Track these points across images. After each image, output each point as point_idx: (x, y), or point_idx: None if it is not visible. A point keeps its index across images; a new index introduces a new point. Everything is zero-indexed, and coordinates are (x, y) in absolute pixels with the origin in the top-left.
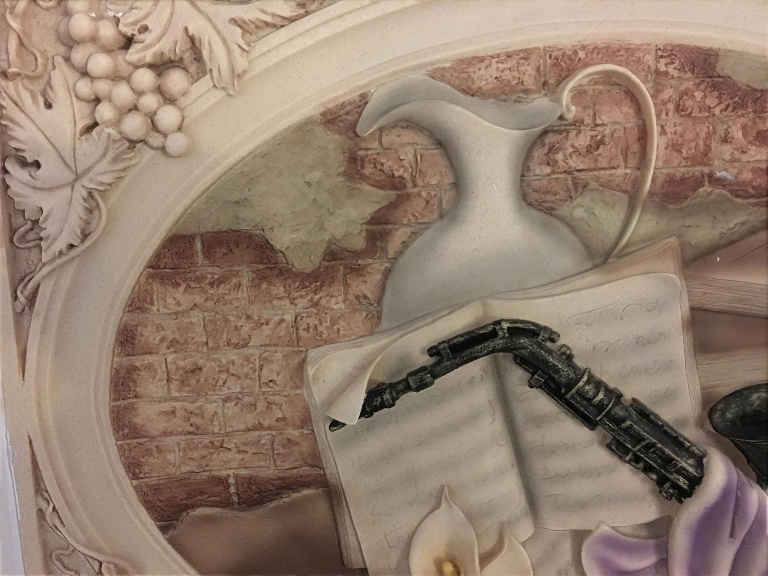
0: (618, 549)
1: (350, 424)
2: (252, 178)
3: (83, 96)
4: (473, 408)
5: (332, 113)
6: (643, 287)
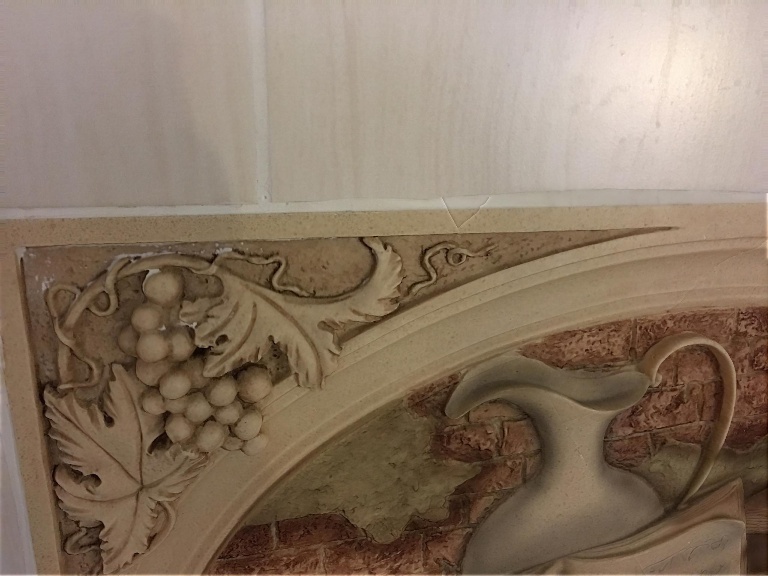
0: None
1: None
2: (334, 465)
3: (153, 414)
4: None
5: (420, 396)
6: (711, 530)
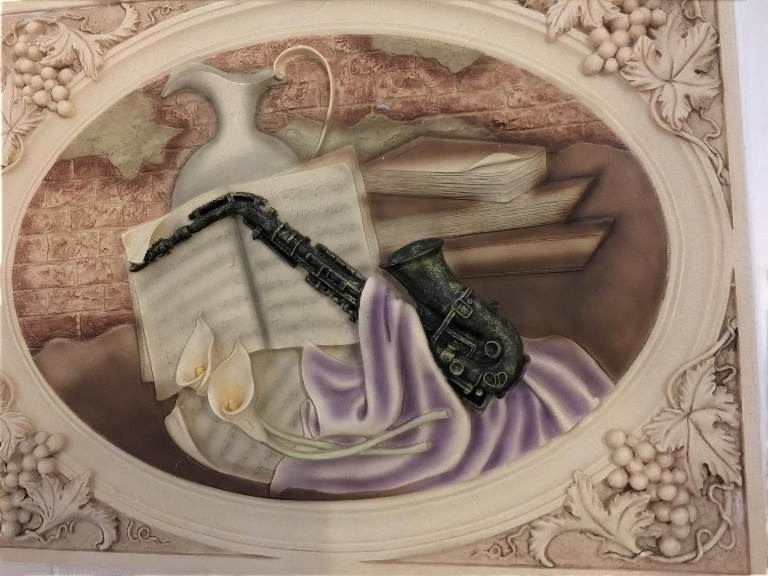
0: (328, 369)
1: (138, 262)
2: (103, 125)
3: (17, 83)
4: (219, 256)
5: (149, 87)
6: (328, 174)
